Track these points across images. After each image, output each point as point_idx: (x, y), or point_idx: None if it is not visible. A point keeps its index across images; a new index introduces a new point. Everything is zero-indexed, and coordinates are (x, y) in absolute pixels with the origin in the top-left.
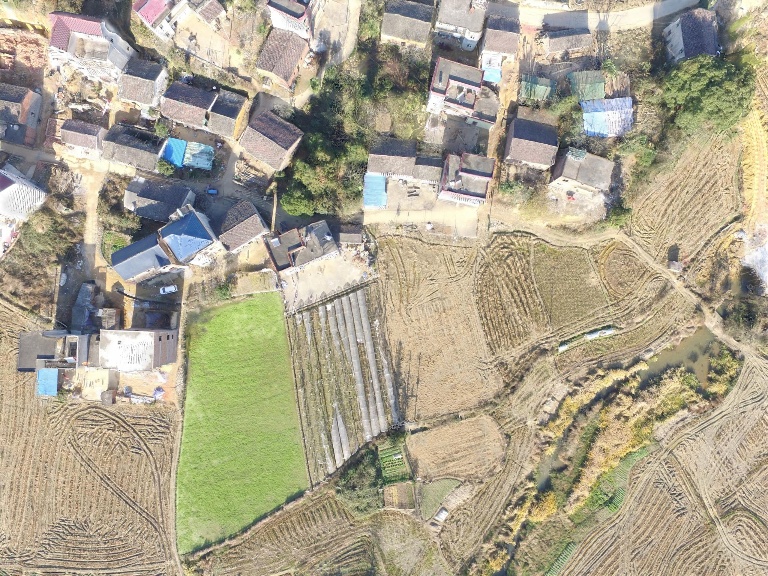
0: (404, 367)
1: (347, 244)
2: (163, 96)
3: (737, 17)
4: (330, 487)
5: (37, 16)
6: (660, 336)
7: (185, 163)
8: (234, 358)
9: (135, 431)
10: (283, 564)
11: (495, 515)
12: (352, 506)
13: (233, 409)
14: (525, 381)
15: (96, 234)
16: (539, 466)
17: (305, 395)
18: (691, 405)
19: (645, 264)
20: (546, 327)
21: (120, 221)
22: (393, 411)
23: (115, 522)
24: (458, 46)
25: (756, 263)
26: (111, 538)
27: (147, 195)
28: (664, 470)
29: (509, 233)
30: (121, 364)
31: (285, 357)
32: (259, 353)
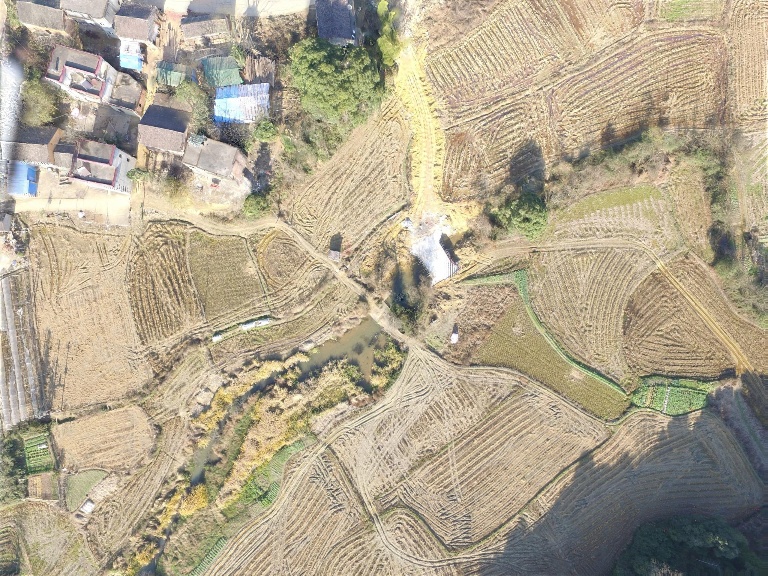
0: (52, 356)
1: None
2: None
3: (401, 2)
4: None
5: None
6: (321, 327)
7: None
8: None
9: None
10: None
11: (145, 508)
12: None
13: None
14: (177, 372)
15: None
16: (193, 459)
17: None
18: (351, 398)
19: (305, 253)
20: (198, 317)
21: None
22: (33, 400)
23: None
24: (105, 34)
25: (422, 253)
26: None
27: None
28: (321, 465)
29: (164, 221)
30: None
31: None
32: None
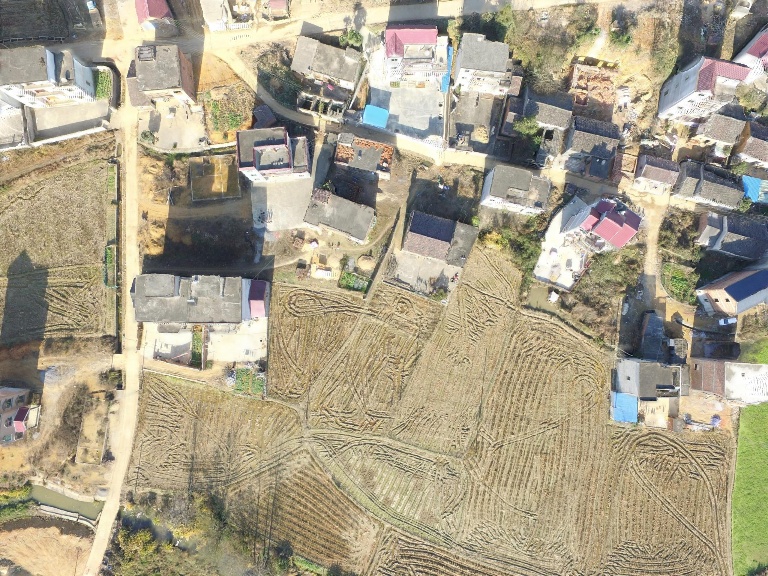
0: None
1: None
2: (752, 136)
3: None
4: None
5: (622, 55)
6: None
7: (757, 200)
8: None
9: (692, 457)
10: None
11: None
12: None
13: None
14: None
15: (655, 265)
16: None
17: None
18: None
19: None
20: None
21: (688, 254)
22: None
23: (675, 545)
24: None
25: None
26: (671, 561)
27: (735, 231)
28: None
29: None
30: (745, 395)
31: None
32: None
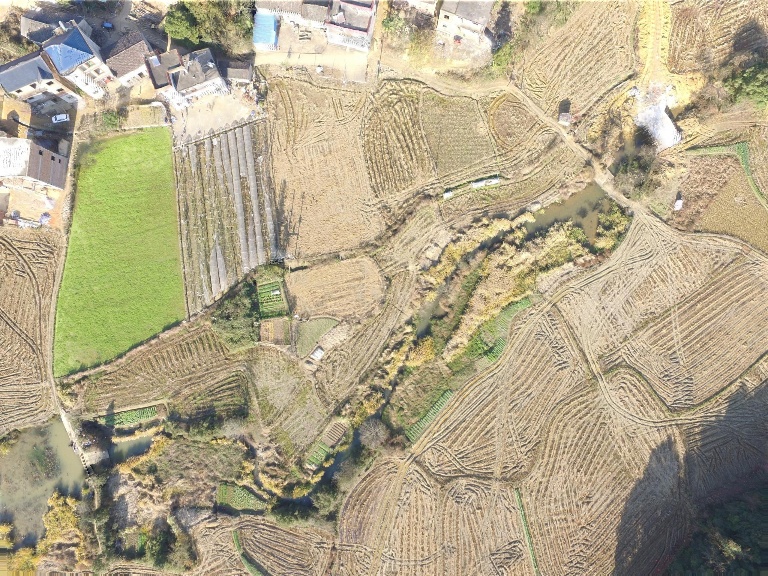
0: (287, 205)
1: (236, 82)
2: None
3: None
4: (206, 318)
5: None
6: (548, 189)
7: None
8: (121, 189)
9: (20, 254)
10: (157, 394)
11: (372, 358)
12: (226, 337)
13: (117, 238)
14: (408, 226)
15: None
16: (420, 313)
17: (188, 228)
18: (577, 259)
19: (535, 117)
20: (431, 173)
21: (18, 50)
22: (271, 244)
23: None
24: None
25: (649, 121)
26: None
27: (40, 19)
28: (546, 322)
29: (399, 80)
30: None
31: (171, 190)
32: (145, 185)
